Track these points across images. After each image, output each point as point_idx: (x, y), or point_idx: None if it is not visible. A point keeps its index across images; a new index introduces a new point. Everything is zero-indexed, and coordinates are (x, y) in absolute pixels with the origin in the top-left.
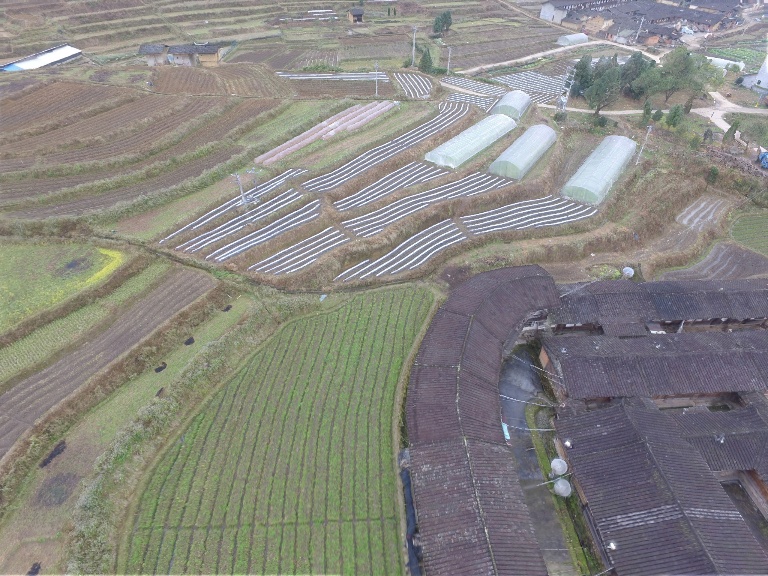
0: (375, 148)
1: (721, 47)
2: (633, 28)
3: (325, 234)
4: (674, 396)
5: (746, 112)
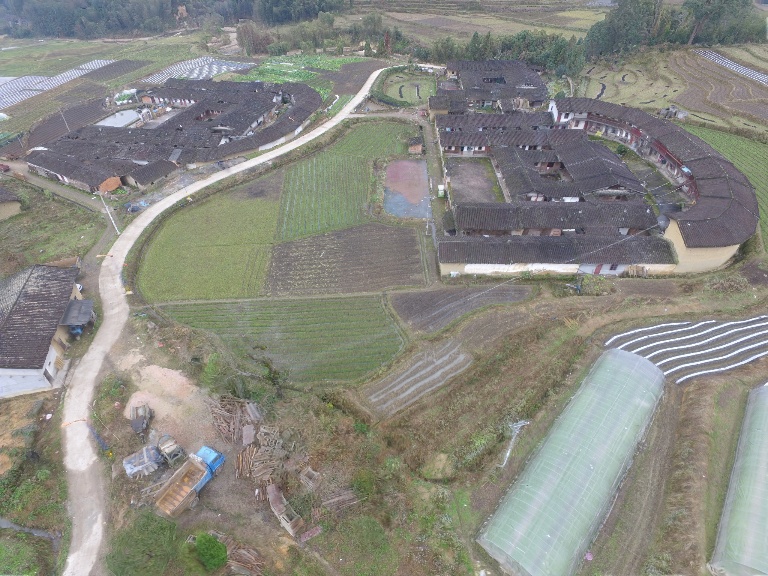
0: None
1: None
2: None
3: None
4: None
5: None
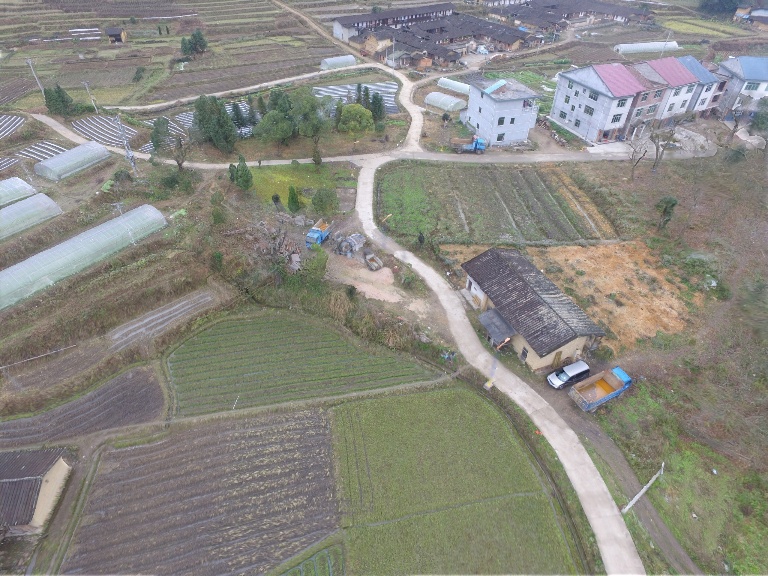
0: None
1: (501, 70)
2: (408, 49)
3: None
4: None
5: (419, 158)
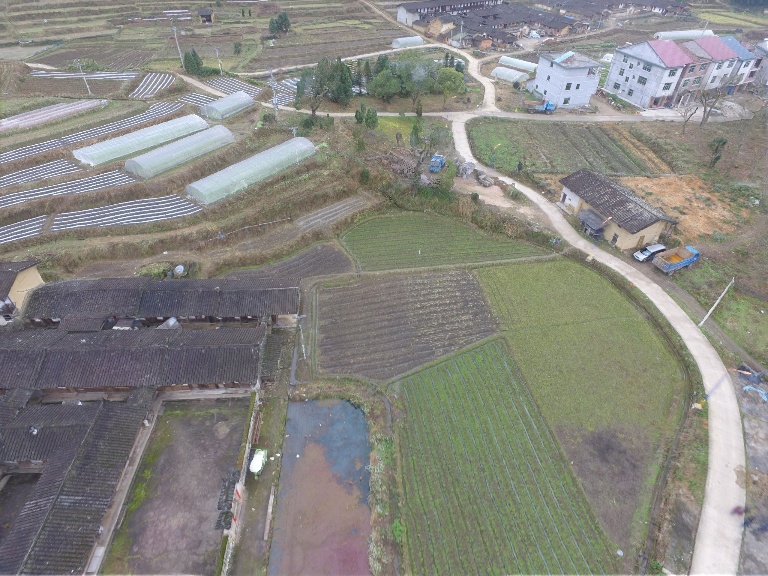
0: (31, 145)
1: None
2: (470, 32)
3: None
4: (84, 390)
5: (499, 116)
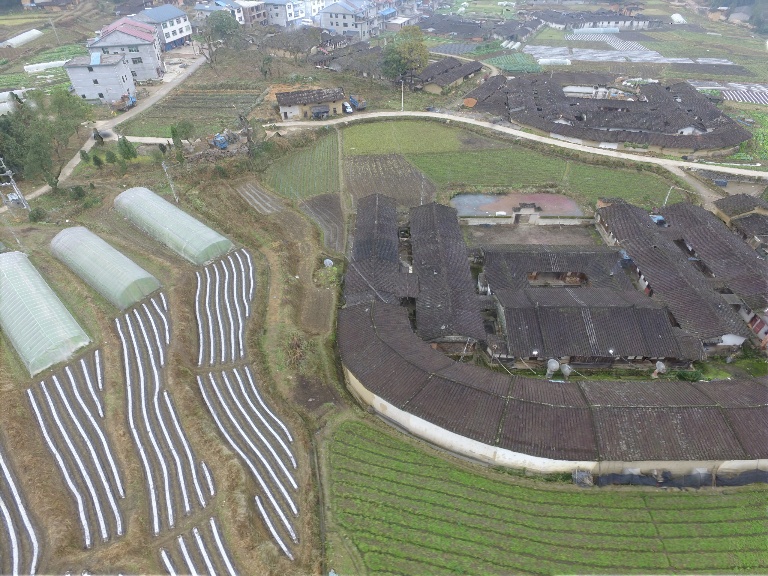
0: None
1: None
2: None
3: (178, 567)
4: None
5: (120, 122)
